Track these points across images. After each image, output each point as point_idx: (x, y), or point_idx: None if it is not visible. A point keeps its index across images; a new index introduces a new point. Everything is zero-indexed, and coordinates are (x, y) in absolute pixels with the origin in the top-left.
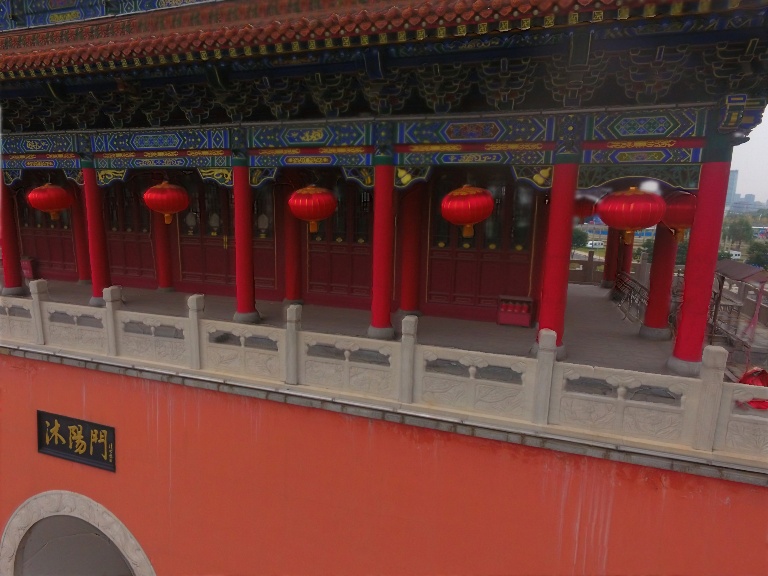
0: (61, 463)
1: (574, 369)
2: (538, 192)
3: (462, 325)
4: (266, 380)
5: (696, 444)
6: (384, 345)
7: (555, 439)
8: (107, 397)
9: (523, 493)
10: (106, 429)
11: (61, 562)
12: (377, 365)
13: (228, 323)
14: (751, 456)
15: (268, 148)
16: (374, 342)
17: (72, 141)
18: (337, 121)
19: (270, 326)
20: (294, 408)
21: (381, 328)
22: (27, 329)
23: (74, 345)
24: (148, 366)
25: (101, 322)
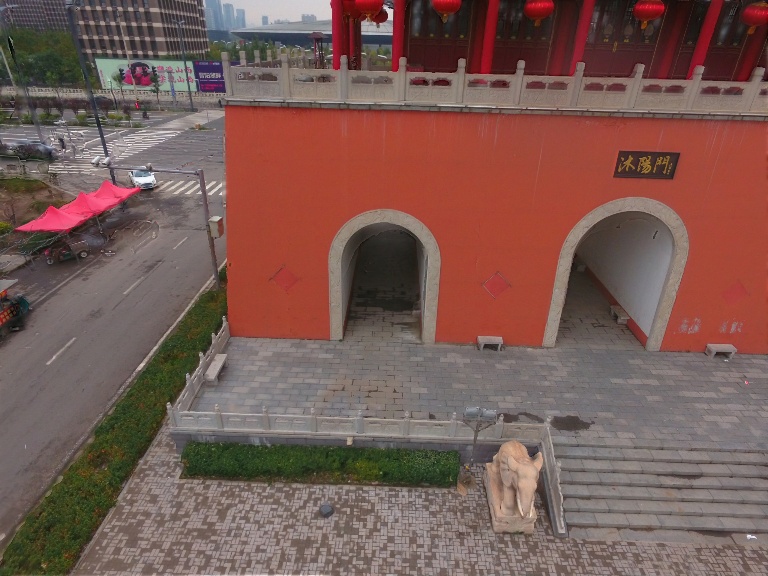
0: (632, 181)
1: None
2: None
3: None
4: None
5: None
6: None
7: None
8: (680, 135)
9: None
10: (671, 155)
11: None
12: None
13: None
14: None
15: None
16: None
17: None
18: None
19: None
20: None
21: None
22: (619, 99)
23: (657, 106)
24: (721, 112)
25: (684, 89)
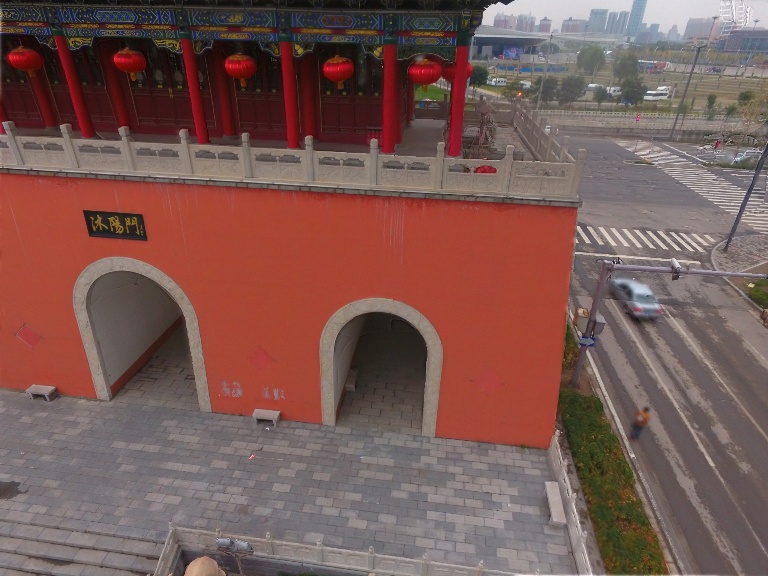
0: (108, 240)
1: (386, 157)
2: (377, 61)
3: (345, 147)
4: (234, 177)
5: (435, 186)
6: (297, 152)
7: (379, 190)
8: (133, 196)
9: (367, 218)
10: (136, 216)
11: (108, 310)
12: (294, 163)
13: (206, 146)
14: (455, 189)
15: (205, 26)
16: (291, 151)
17: (40, 12)
18: (252, 9)
19: (232, 146)
20: (252, 190)
21: (294, 148)
22: (62, 158)
23: (101, 167)
24: (159, 175)
25: (119, 150)
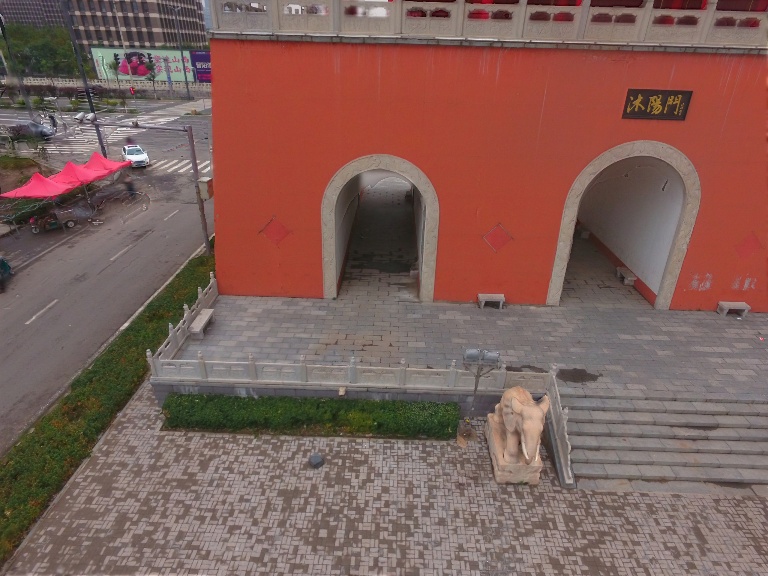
0: (641, 122)
1: None
2: None
3: None
4: None
5: None
6: None
7: None
8: (693, 71)
9: None
10: (683, 94)
11: None
12: None
13: None
14: None
15: None
16: None
17: None
18: None
19: None
20: None
21: None
22: (629, 31)
23: (668, 39)
24: (736, 45)
25: (697, 20)
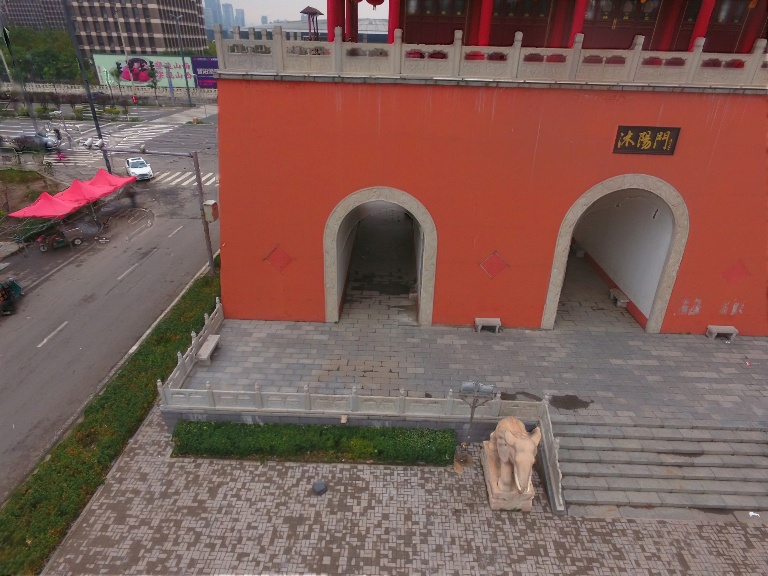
0: (631, 157)
1: None
2: None
3: None
4: None
5: None
6: None
7: None
8: (680, 109)
9: None
10: (671, 130)
11: None
12: None
13: None
14: None
15: None
16: None
17: None
18: None
19: None
20: None
21: None
22: (619, 72)
23: (657, 79)
24: (722, 85)
25: (684, 62)
